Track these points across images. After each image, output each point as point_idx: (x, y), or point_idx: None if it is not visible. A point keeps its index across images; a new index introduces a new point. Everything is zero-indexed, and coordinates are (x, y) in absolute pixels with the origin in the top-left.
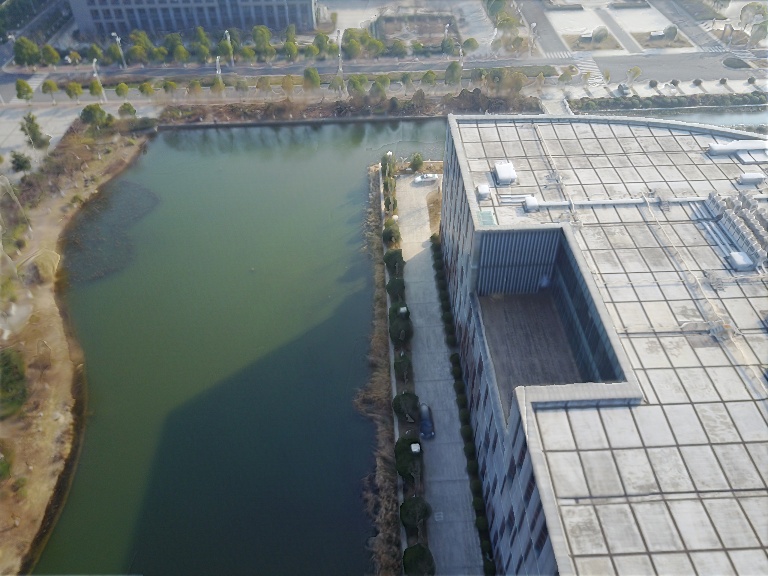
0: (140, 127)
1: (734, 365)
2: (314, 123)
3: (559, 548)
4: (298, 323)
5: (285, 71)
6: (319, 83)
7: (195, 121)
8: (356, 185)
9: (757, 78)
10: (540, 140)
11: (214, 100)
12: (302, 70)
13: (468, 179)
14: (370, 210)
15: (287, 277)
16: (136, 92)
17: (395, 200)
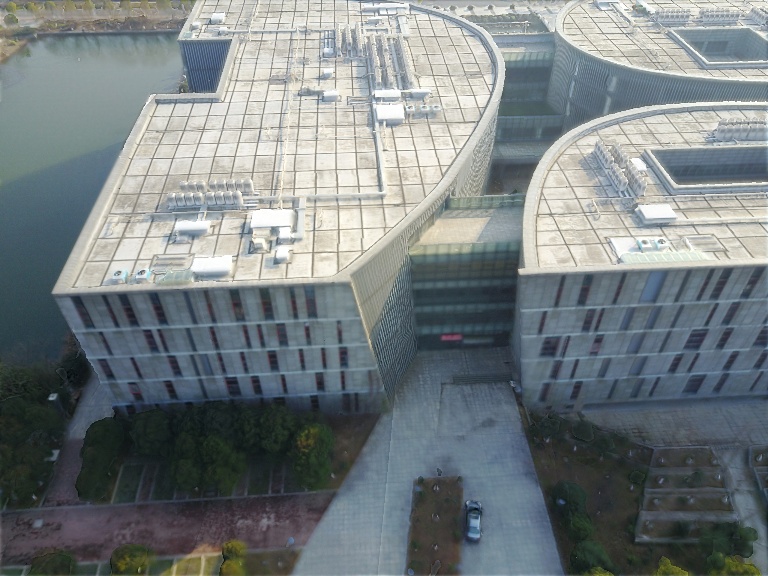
0: (22, 33)
1: (286, 90)
2: (162, 33)
3: (130, 139)
4: (105, 141)
5: None
6: (170, 4)
7: (67, 30)
8: (178, 68)
9: (518, 6)
10: (257, 4)
11: (87, 18)
12: None
13: (190, 19)
14: (182, 82)
15: (107, 118)
16: (25, 12)
17: None
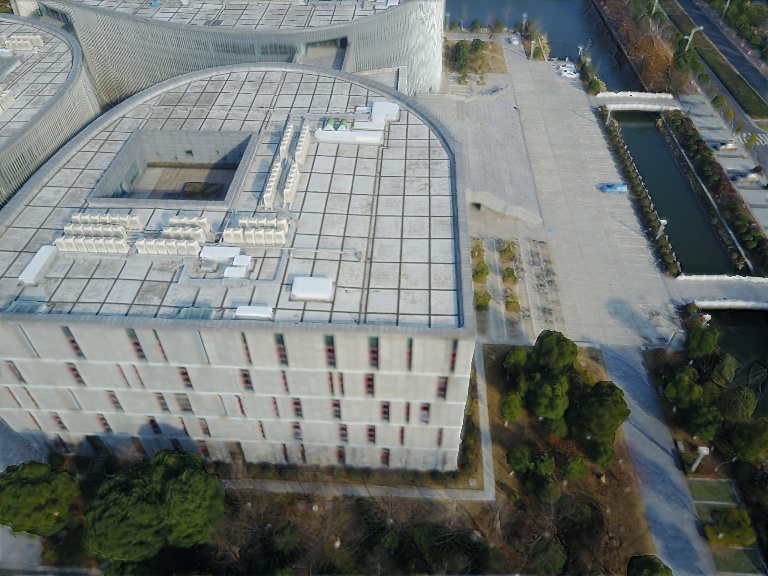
0: None
1: None
2: None
3: None
4: None
5: (687, 5)
6: None
7: None
8: None
9: None
10: None
11: None
12: (697, 12)
13: None
14: None
15: None
16: None
17: (475, 22)
